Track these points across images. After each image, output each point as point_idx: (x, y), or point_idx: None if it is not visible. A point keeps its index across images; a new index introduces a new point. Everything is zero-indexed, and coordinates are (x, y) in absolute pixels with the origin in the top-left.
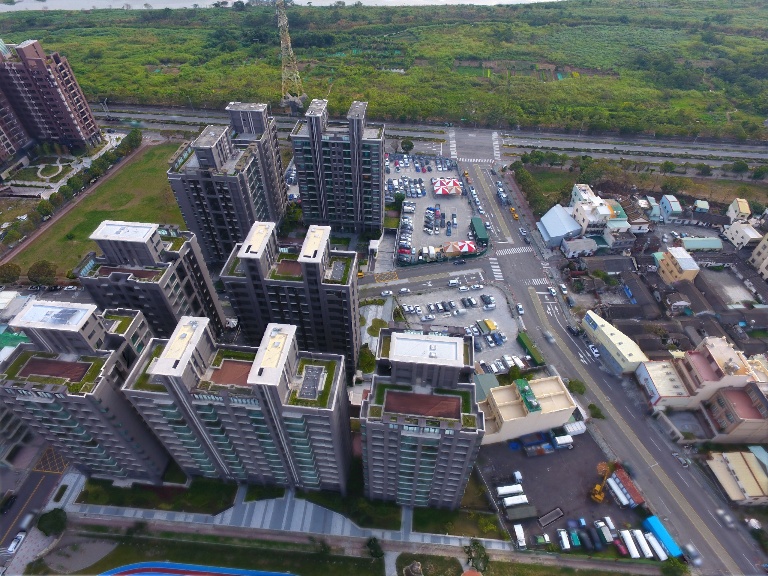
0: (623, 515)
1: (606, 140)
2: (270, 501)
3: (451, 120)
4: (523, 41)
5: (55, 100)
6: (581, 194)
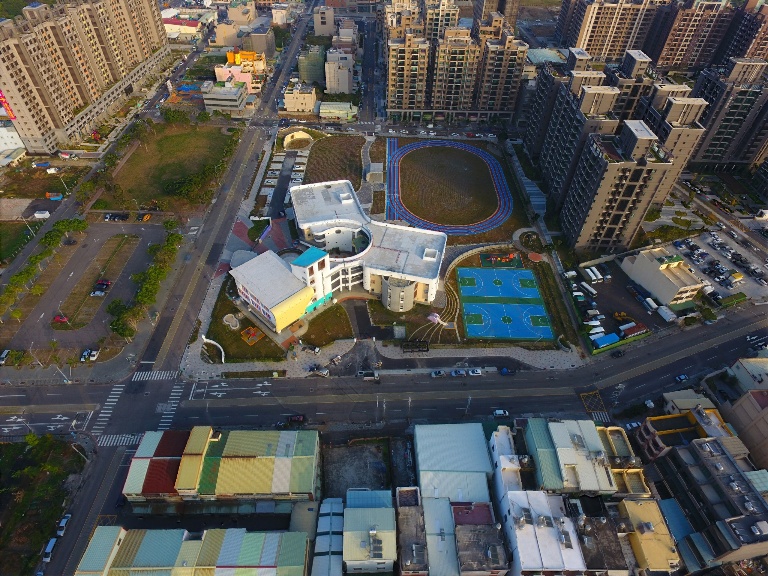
0: (611, 331)
1: None
2: (540, 191)
3: None
4: None
5: (746, 46)
6: None
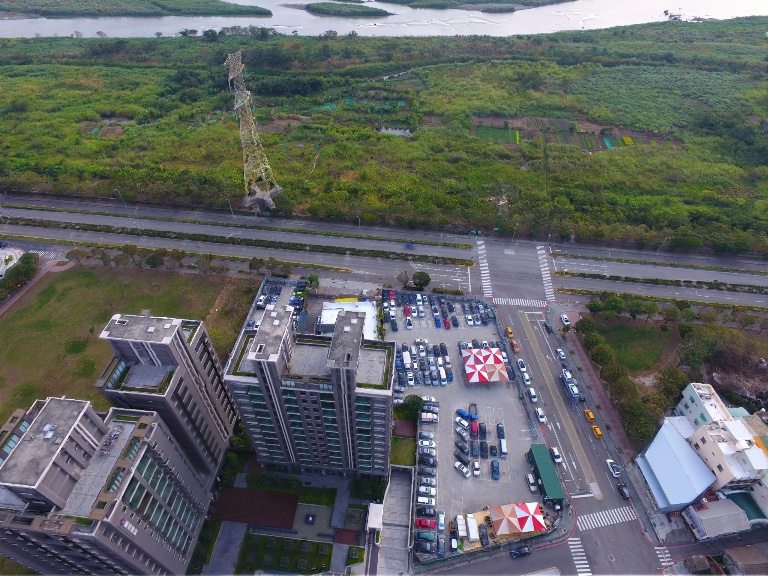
0: None
1: (697, 262)
2: None
3: (478, 224)
4: (554, 89)
5: None
6: (706, 409)
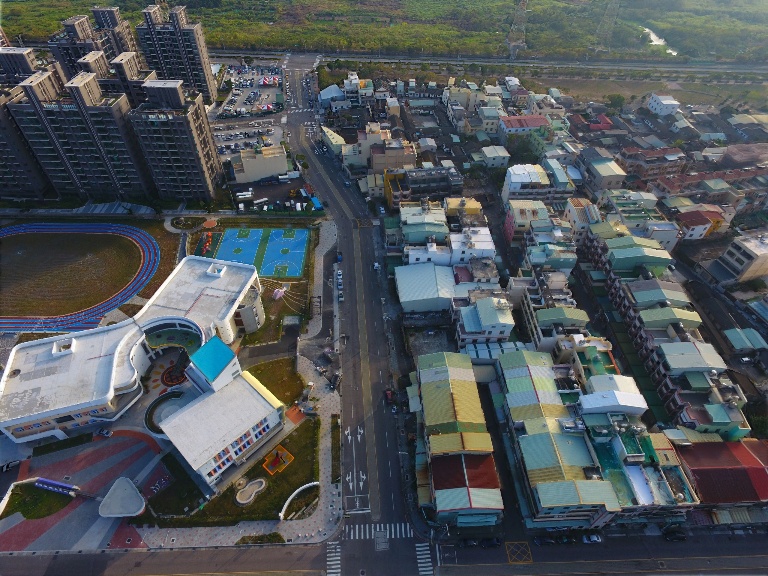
0: (304, 202)
1: (398, 58)
2: (107, 204)
3: (290, 48)
4: (375, 3)
5: None
6: (348, 76)
